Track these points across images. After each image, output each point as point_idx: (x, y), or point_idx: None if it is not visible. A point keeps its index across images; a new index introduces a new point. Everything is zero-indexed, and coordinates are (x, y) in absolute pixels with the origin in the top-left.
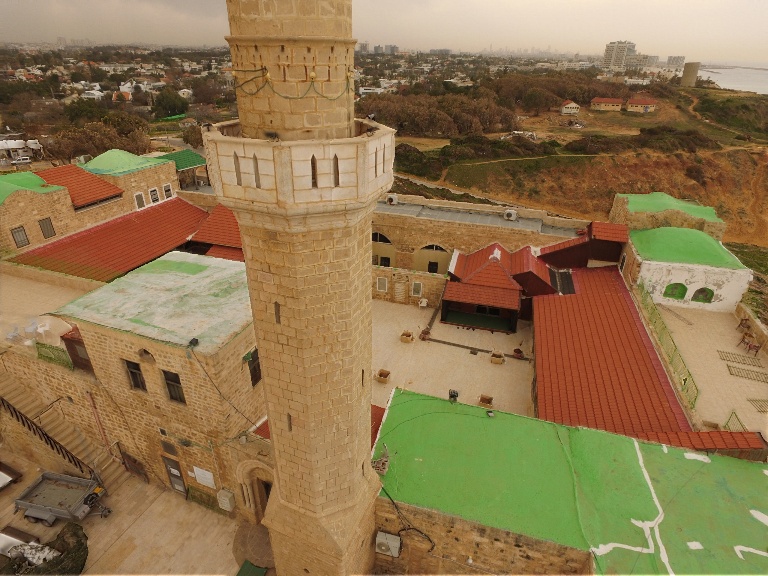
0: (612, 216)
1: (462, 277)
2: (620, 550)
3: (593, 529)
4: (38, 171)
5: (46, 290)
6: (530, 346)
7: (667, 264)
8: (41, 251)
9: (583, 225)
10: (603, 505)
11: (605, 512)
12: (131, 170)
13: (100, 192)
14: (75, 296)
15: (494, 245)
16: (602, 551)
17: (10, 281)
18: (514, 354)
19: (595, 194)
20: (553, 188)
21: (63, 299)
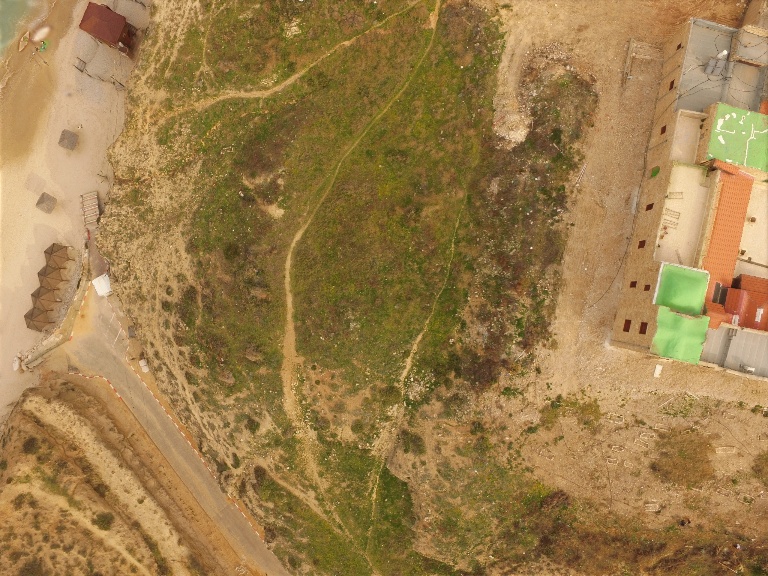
0: None
1: None
2: (762, 131)
3: (767, 136)
4: None
5: None
6: None
7: (699, 270)
8: None
9: (699, 360)
10: (762, 142)
11: (762, 141)
12: None
13: None
14: None
15: None
16: (766, 130)
17: None
18: None
19: None
20: None
21: None
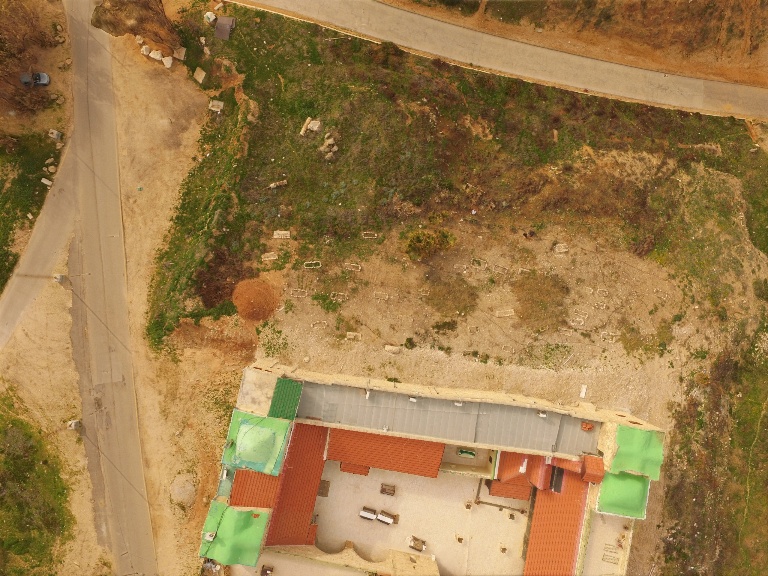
0: (608, 431)
1: (501, 477)
2: None
3: None
4: (230, 494)
5: (304, 561)
6: (529, 502)
7: (608, 513)
8: (272, 528)
9: None
10: None
11: None
12: (277, 460)
13: (274, 487)
14: (321, 564)
15: (525, 454)
16: None
17: (279, 556)
18: (520, 512)
19: (685, 15)
20: (633, 7)
21: (318, 567)
